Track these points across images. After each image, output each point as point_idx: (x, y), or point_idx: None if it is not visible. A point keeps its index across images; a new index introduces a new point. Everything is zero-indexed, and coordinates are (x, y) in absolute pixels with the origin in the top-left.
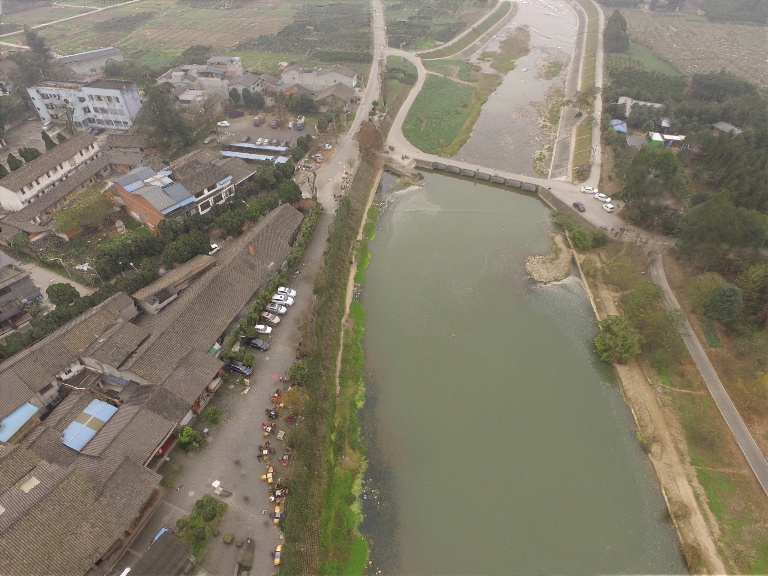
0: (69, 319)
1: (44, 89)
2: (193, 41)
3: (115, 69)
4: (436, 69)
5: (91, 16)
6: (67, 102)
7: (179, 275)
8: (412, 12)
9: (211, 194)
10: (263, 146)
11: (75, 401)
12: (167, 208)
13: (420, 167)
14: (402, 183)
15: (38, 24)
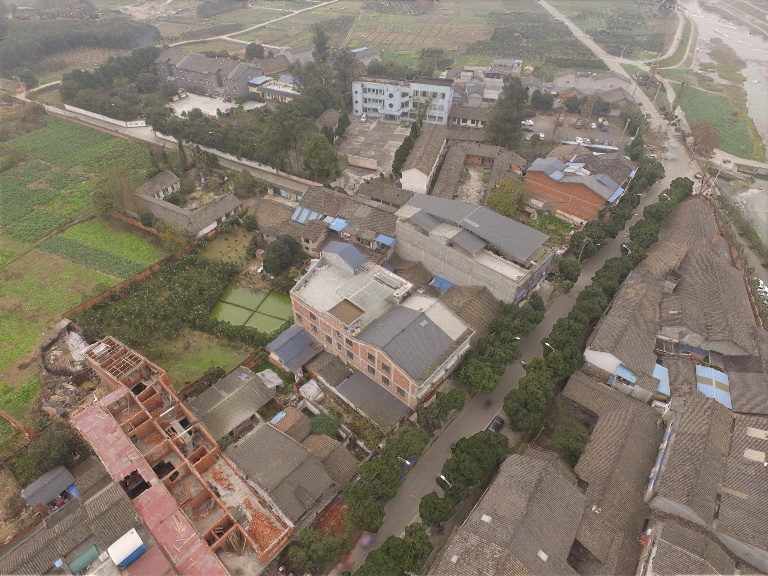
0: (610, 292)
1: (369, 84)
2: (413, 44)
3: (378, 68)
4: (675, 78)
5: (293, 18)
6: (391, 97)
7: (668, 259)
8: (600, 22)
9: (621, 186)
10: (593, 145)
11: (683, 365)
12: (610, 197)
13: (742, 171)
14: (740, 186)
15: (255, 24)
